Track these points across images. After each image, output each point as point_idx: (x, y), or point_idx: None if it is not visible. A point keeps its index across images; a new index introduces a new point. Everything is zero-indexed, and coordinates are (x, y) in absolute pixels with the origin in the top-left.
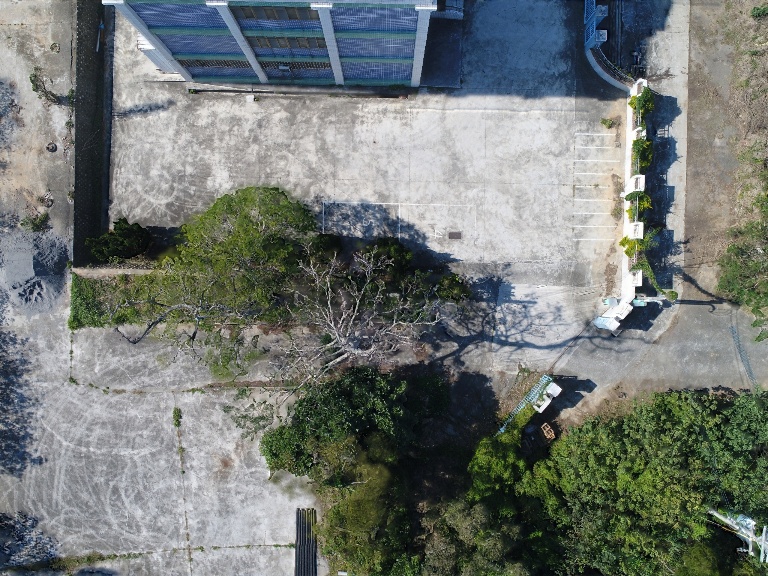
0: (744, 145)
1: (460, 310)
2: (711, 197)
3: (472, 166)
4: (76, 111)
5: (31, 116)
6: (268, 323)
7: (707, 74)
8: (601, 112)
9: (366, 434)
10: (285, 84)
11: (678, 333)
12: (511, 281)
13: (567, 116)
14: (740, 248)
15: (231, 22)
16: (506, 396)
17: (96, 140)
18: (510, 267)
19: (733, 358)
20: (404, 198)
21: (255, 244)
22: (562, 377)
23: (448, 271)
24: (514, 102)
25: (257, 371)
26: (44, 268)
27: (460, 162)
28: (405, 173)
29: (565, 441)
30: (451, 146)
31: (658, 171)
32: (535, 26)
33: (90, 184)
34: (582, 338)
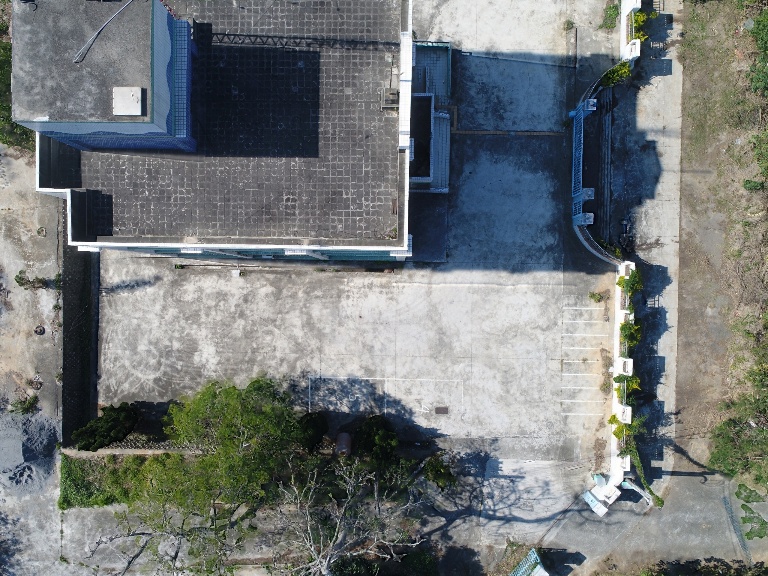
0: (736, 315)
1: (447, 485)
2: (703, 367)
3: (459, 341)
4: (63, 294)
5: (19, 300)
6: (255, 502)
7: (698, 243)
8: (589, 286)
9: None
10: (270, 259)
11: (669, 504)
12: (499, 456)
13: (555, 290)
14: (732, 420)
15: None
16: (494, 570)
17: (84, 317)
18: (497, 442)
19: (726, 529)
20: (390, 373)
21: (235, 468)
22: (551, 550)
23: (435, 446)
24: (501, 276)
25: (245, 549)
26: (33, 453)
27: (446, 337)
28: (391, 348)
29: None
30: (437, 321)
31: (648, 341)
32: (522, 199)
33: (79, 360)
34: (571, 511)
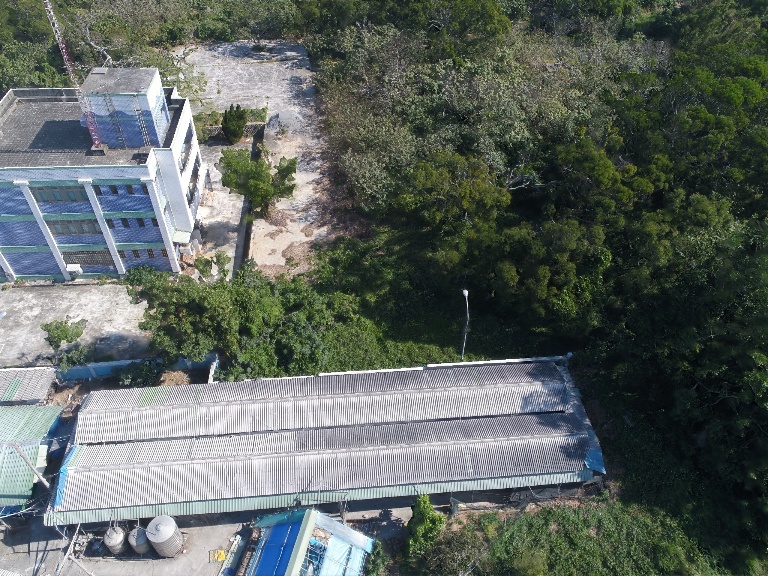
0: None
1: None
2: None
3: None
4: None
5: None
6: None
7: None
8: None
9: None
10: None
11: None
12: None
13: None
14: None
15: None
16: None
17: None
18: None
19: None
20: None
21: None
22: None
23: None
24: None
25: None
26: None
27: None
28: None
29: None
30: None
31: None
32: None
33: None
34: None
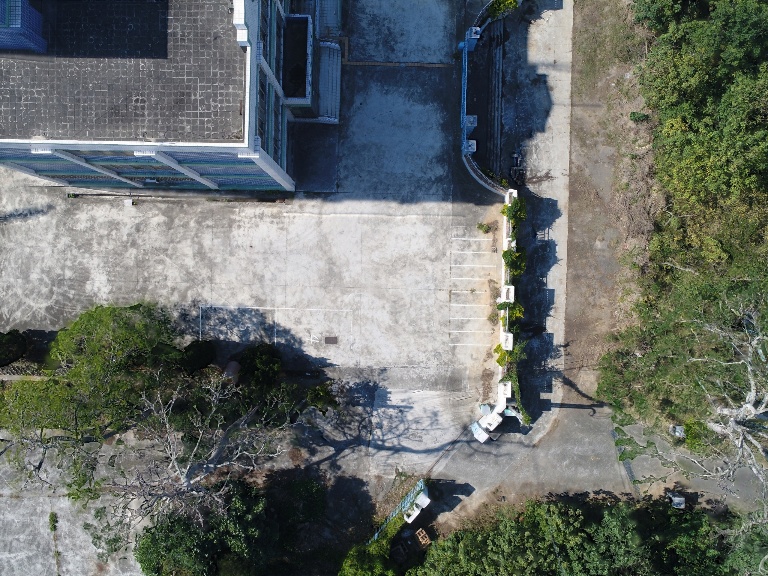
0: (625, 248)
1: (336, 414)
2: (592, 300)
3: (348, 271)
4: None
5: None
6: (143, 429)
7: (588, 176)
8: (478, 217)
9: (219, 556)
10: (162, 188)
11: (558, 437)
12: (387, 386)
13: (443, 221)
14: (620, 352)
15: (70, 159)
16: (383, 500)
17: None
18: (386, 372)
19: (614, 461)
20: (280, 303)
21: (97, 377)
22: (440, 481)
23: (324, 376)
24: (390, 207)
25: None
26: None
27: (336, 267)
28: (281, 278)
29: (442, 546)
30: (327, 251)
31: (538, 274)
32: (412, 130)
33: None
34: (460, 442)
